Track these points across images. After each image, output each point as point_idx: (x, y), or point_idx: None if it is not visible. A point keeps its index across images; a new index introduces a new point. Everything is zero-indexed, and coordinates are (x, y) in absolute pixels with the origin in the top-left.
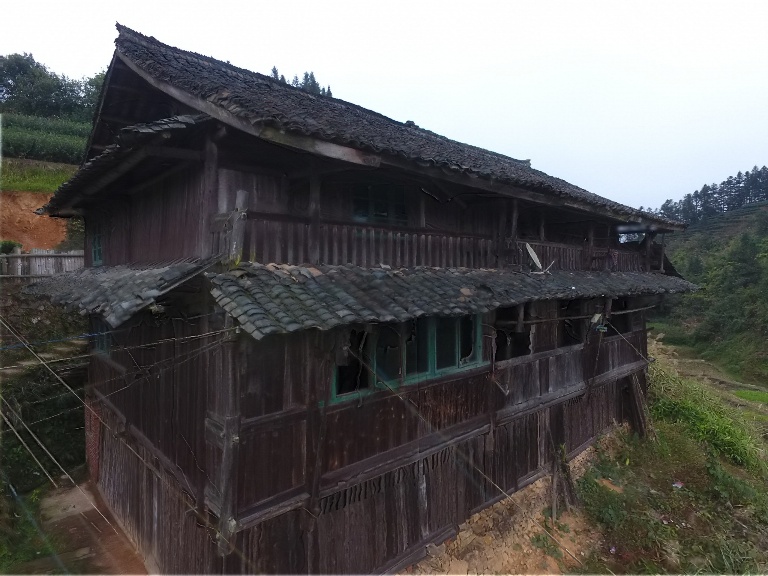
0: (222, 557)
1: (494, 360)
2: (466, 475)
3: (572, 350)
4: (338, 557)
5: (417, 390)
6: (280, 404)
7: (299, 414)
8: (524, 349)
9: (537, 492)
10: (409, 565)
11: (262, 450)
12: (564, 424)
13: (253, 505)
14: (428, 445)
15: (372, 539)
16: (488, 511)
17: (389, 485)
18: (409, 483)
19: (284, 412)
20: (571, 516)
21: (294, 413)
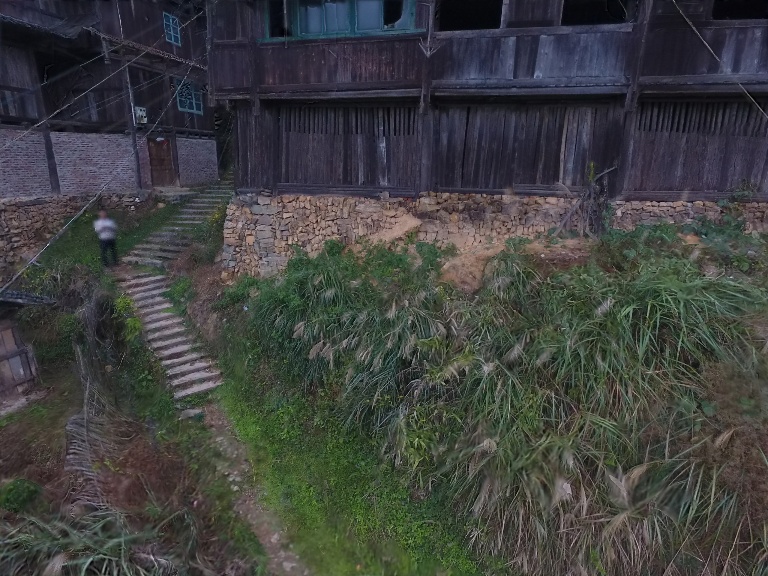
0: (238, 131)
1: (430, 28)
2: (433, 152)
3: (597, 30)
4: (303, 161)
5: (335, 43)
6: (235, 36)
7: (246, 44)
8: (490, 23)
9: (546, 207)
10: (362, 196)
11: (226, 60)
12: (628, 149)
13: (223, 88)
14: (345, 88)
15: (330, 163)
16: (462, 196)
17: (348, 132)
18: (366, 136)
19: (236, 41)
20: (581, 240)
21: (243, 43)
